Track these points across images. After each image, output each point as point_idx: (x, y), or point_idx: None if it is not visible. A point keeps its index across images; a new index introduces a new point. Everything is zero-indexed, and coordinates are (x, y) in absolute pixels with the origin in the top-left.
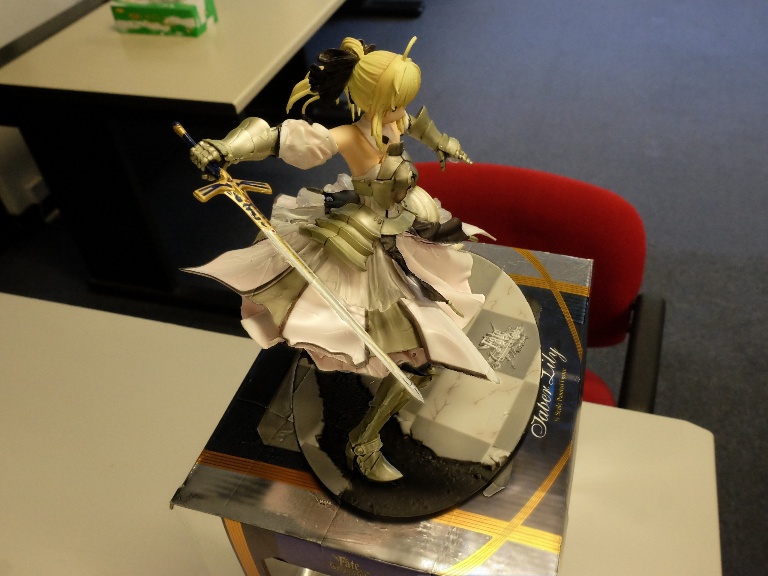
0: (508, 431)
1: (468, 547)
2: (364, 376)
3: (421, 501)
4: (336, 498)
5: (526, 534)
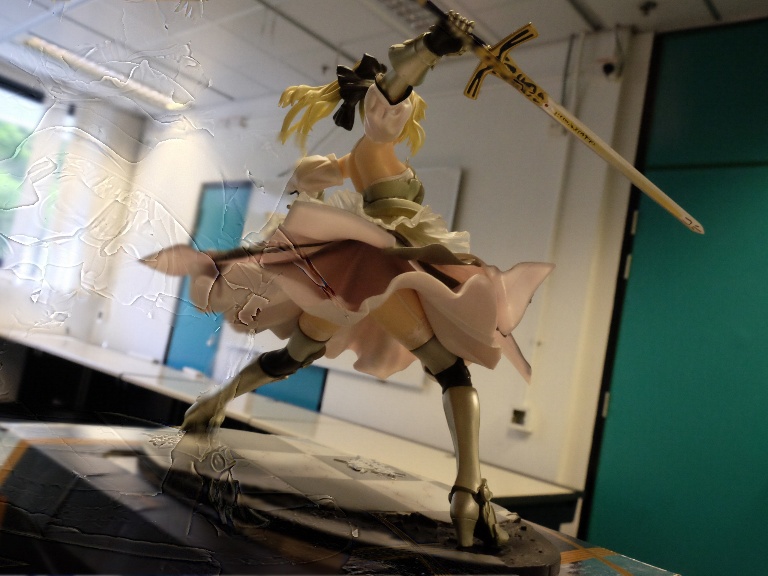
0: (299, 484)
1: (418, 567)
2: (29, 476)
3: (318, 543)
4: (205, 575)
5: (433, 547)
